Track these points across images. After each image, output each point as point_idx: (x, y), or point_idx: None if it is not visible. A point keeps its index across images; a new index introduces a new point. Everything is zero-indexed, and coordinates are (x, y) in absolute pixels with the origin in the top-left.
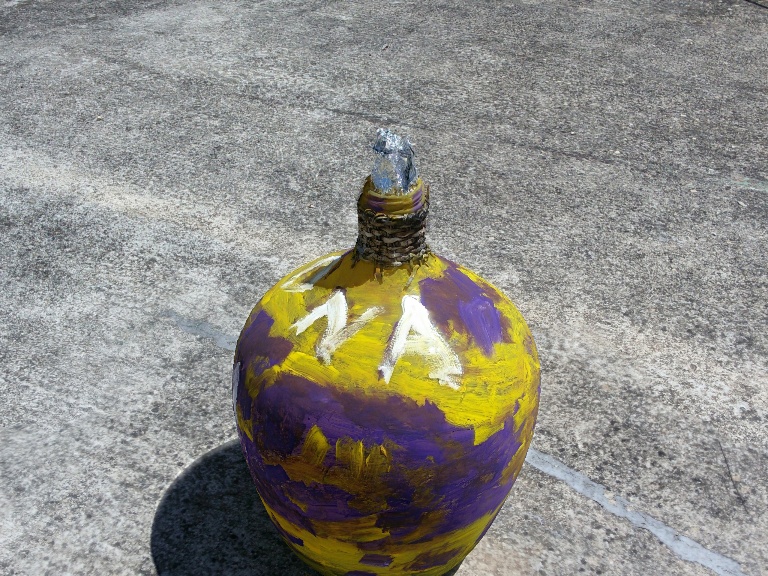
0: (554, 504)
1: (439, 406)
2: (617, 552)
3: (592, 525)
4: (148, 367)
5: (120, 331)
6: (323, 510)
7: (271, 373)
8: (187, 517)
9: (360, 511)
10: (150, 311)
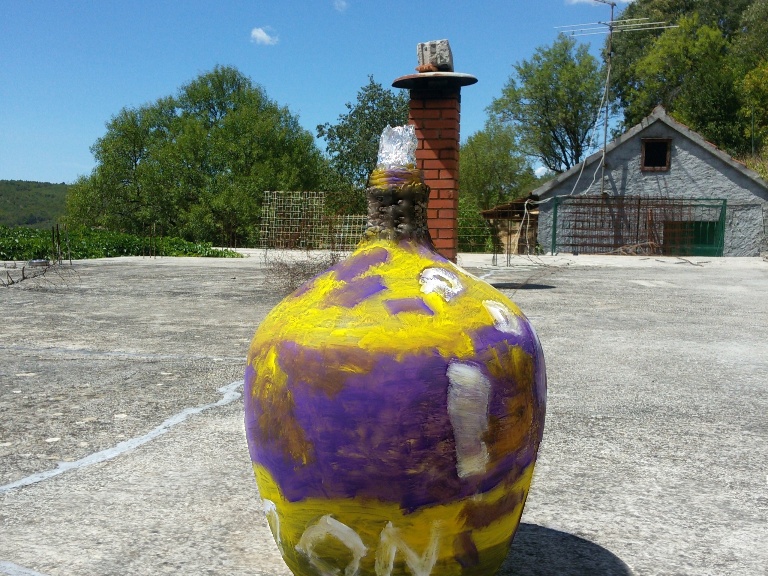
0: None
1: None
2: (139, 575)
3: None
4: None
5: None
6: None
7: None
8: (589, 561)
9: None
10: None
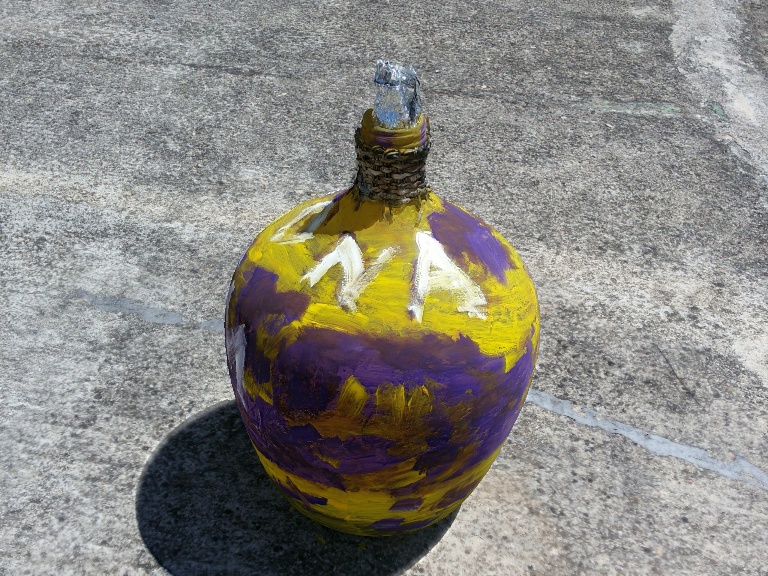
0: (531, 425)
1: (473, 338)
2: (600, 459)
3: (571, 439)
4: (74, 353)
5: (29, 319)
6: (359, 462)
7: (291, 329)
8: (171, 501)
9: (399, 456)
10: (56, 294)
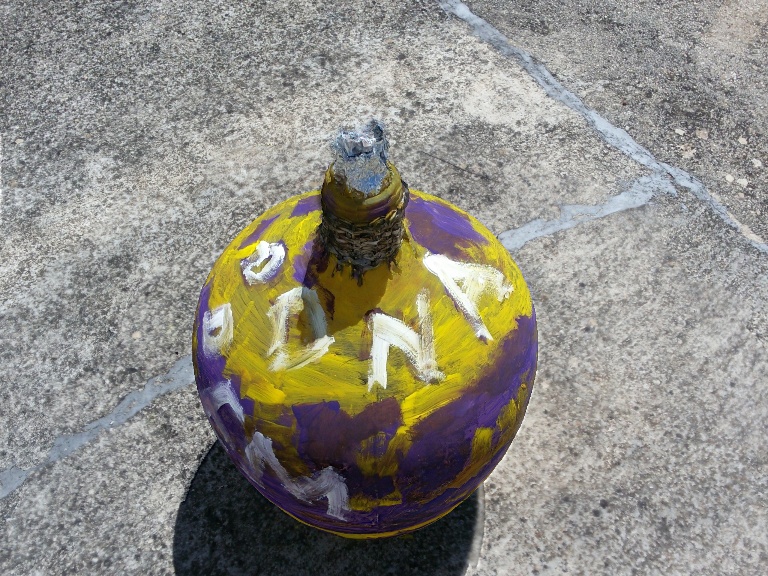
0: None
1: (522, 314)
2: None
3: None
4: None
5: None
6: None
7: (400, 439)
8: None
9: (509, 444)
10: None
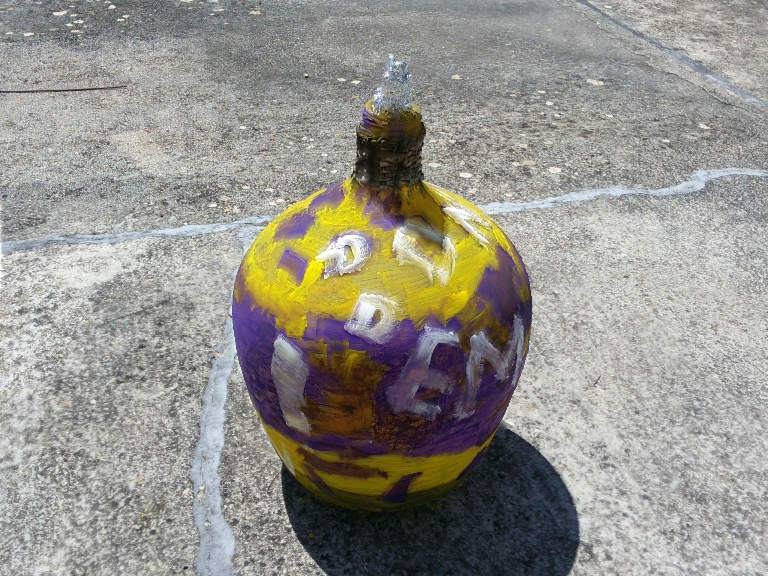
0: None
1: None
2: None
3: None
4: None
5: None
6: None
7: None
8: (521, 573)
9: None
10: None
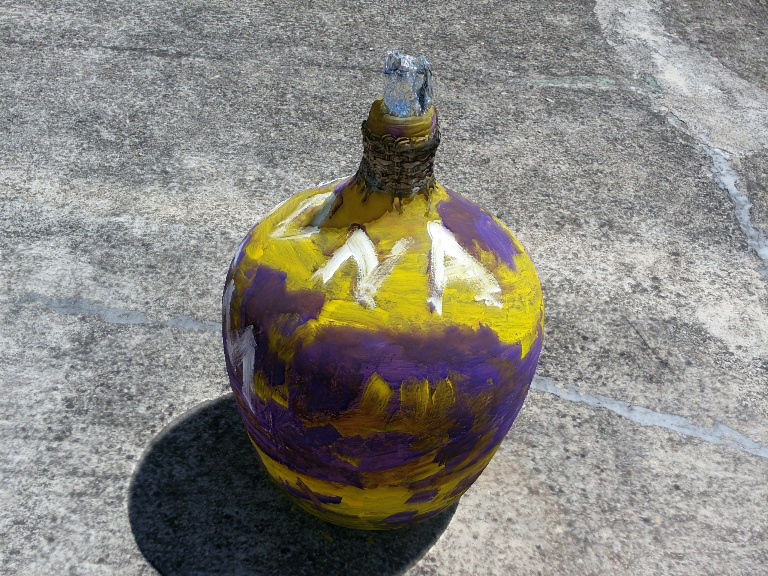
0: None
1: (492, 327)
2: (589, 434)
3: (558, 415)
4: (37, 361)
5: None
6: (380, 459)
7: (307, 329)
8: (166, 510)
9: (421, 450)
10: (7, 298)
